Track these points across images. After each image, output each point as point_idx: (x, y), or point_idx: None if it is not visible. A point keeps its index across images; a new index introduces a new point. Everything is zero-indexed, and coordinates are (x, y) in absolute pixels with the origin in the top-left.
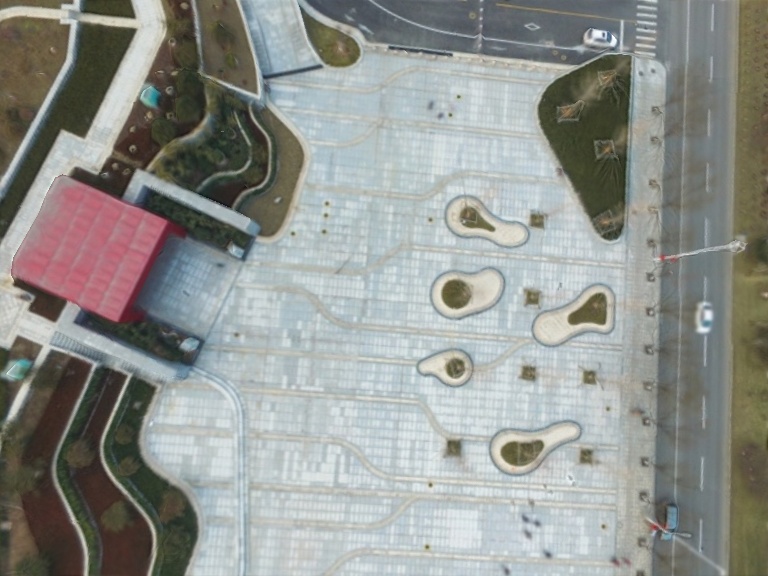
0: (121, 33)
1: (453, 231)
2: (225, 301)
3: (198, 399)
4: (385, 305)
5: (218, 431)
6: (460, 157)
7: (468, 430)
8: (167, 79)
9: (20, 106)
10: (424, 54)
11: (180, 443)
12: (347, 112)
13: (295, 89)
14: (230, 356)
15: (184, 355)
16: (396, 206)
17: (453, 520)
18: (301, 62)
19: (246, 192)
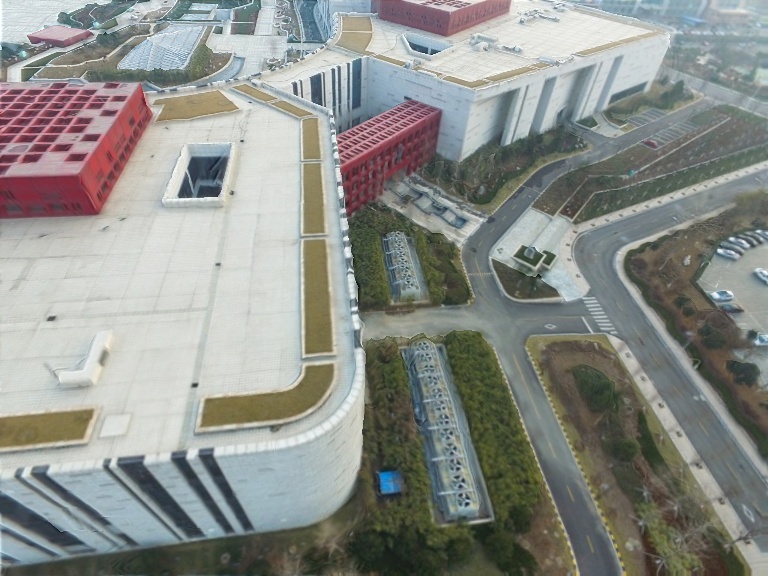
0: None
1: None
2: None
3: None
4: None
5: None
6: None
7: None
8: None
9: None
10: None
11: None
12: None
13: None
14: None
15: None
16: None
17: None
18: None
19: None
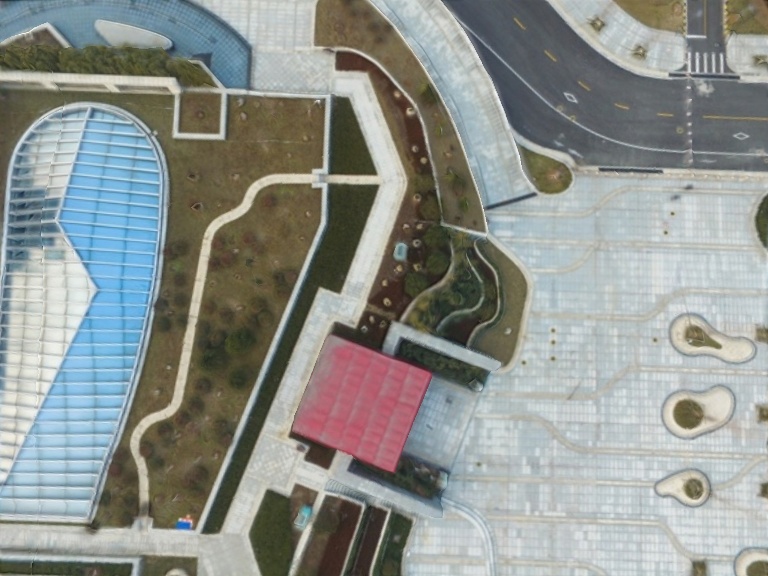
0: (366, 191)
1: (679, 350)
2: (466, 432)
3: (449, 529)
4: (618, 428)
5: (471, 559)
6: (679, 275)
7: (711, 550)
8: (413, 232)
9: (284, 270)
10: (635, 174)
11: (436, 572)
12: (564, 237)
13: (512, 219)
14: (474, 485)
15: (440, 491)
16: (620, 328)
17: None
18: (516, 192)
19: (479, 327)
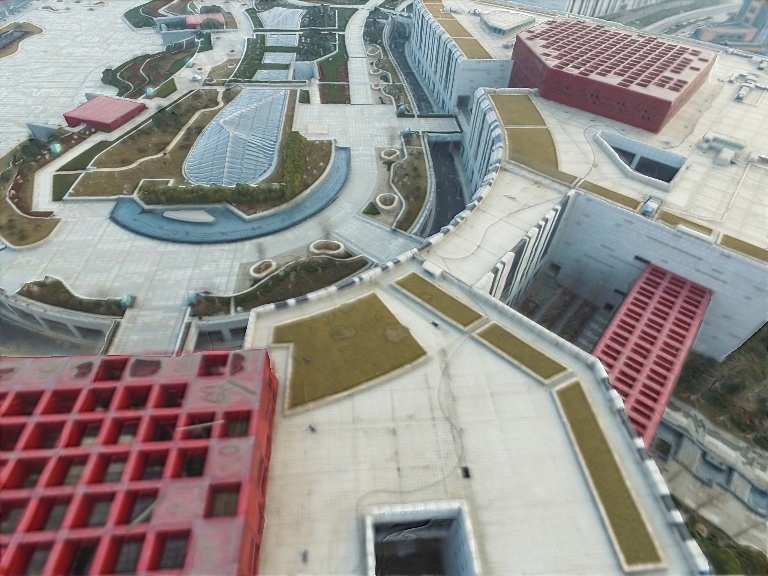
0: (64, 169)
1: None
2: None
3: None
4: None
5: None
6: None
7: None
8: None
9: (127, 142)
10: None
11: None
12: None
13: None
14: None
15: None
16: None
17: None
18: None
19: None
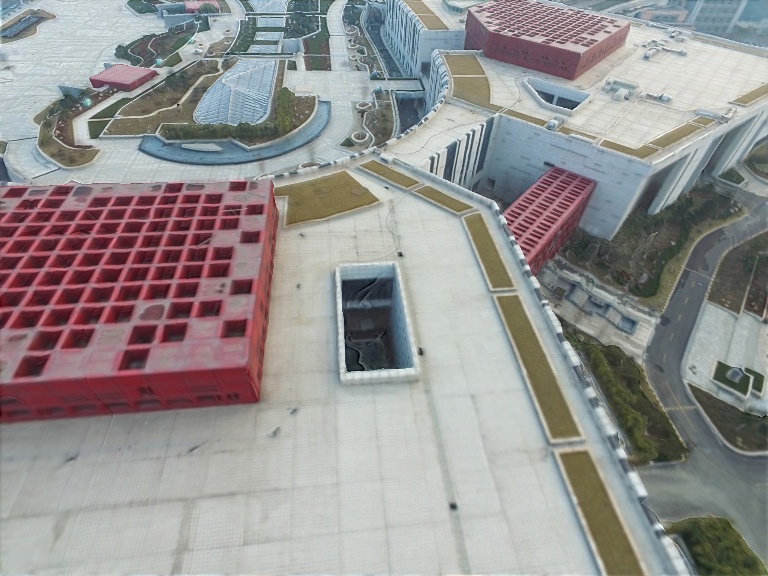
0: (96, 117)
1: None
2: None
3: None
4: None
5: None
6: None
7: None
8: None
9: None
10: None
11: None
12: None
13: None
14: None
15: None
16: None
17: (19, 58)
18: None
19: None
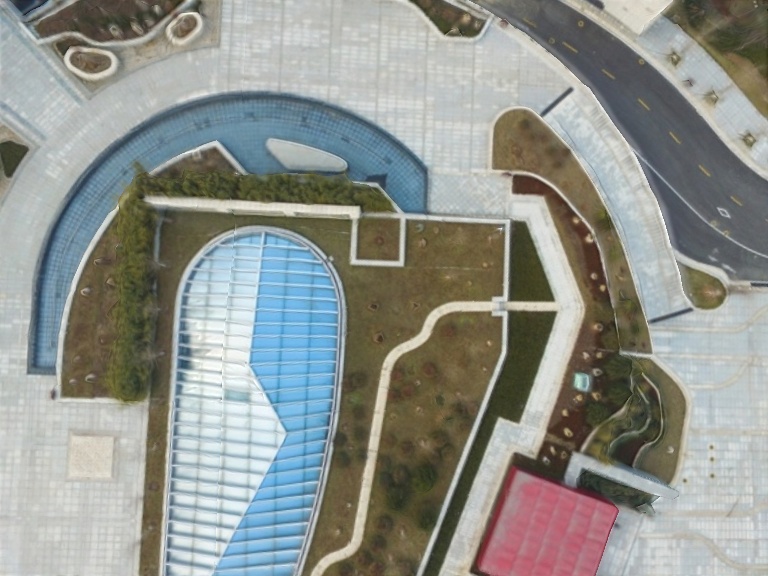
0: (544, 318)
1: None
2: (630, 553)
3: None
4: None
5: None
6: None
7: None
8: (592, 361)
9: (467, 402)
10: None
11: None
12: (719, 353)
13: (669, 334)
14: None
15: None
16: None
17: None
18: (673, 307)
19: (644, 447)
